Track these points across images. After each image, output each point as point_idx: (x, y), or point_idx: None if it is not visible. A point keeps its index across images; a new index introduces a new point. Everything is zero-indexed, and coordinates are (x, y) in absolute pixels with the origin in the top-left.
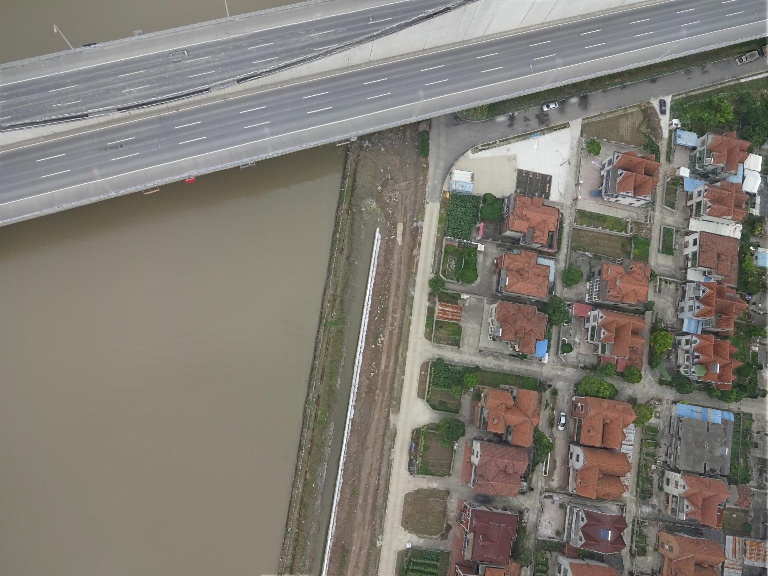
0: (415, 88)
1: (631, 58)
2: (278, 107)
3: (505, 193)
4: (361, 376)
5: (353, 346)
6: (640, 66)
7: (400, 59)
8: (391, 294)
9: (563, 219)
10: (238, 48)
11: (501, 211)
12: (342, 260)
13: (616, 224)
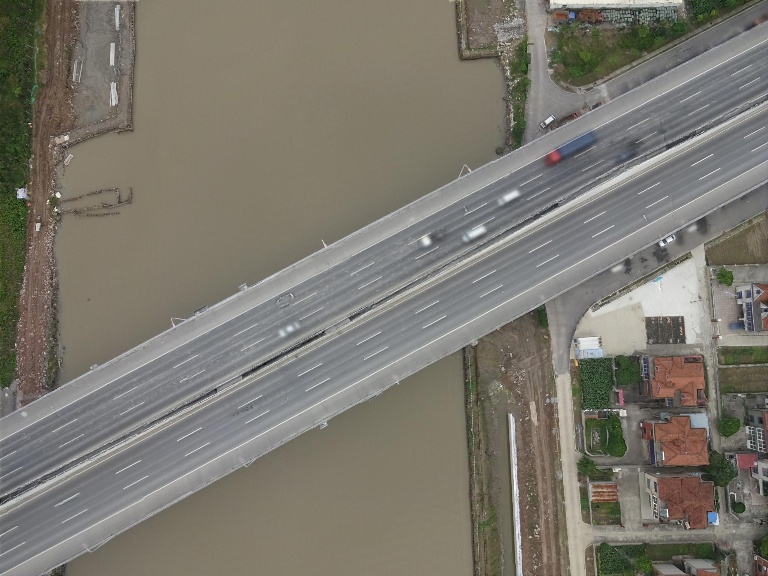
0: (526, 273)
1: (752, 177)
2: (393, 329)
3: (637, 347)
4: (524, 570)
5: (509, 538)
6: (764, 183)
7: (505, 246)
8: (538, 480)
9: (705, 361)
10: (341, 277)
11: (639, 375)
12: (481, 456)
13: (765, 353)
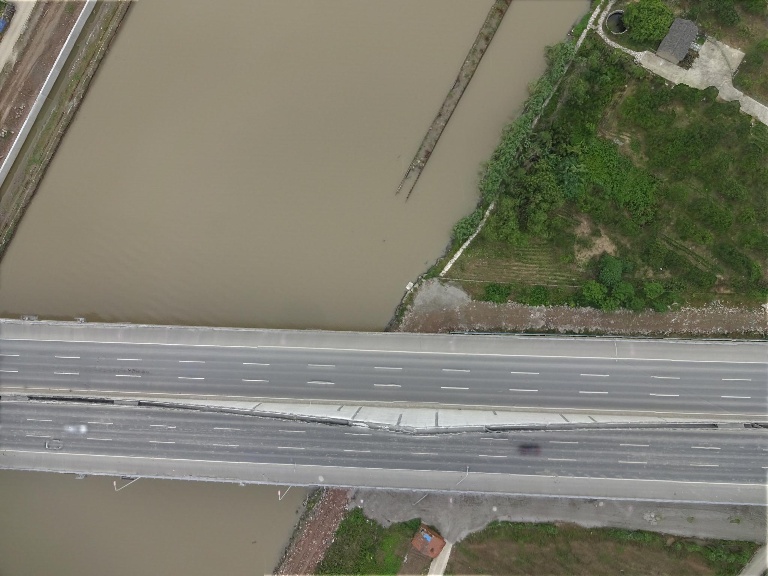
0: None
1: None
2: None
3: None
4: None
5: None
6: None
7: None
8: None
9: None
10: None
11: None
12: (8, 218)
13: None
